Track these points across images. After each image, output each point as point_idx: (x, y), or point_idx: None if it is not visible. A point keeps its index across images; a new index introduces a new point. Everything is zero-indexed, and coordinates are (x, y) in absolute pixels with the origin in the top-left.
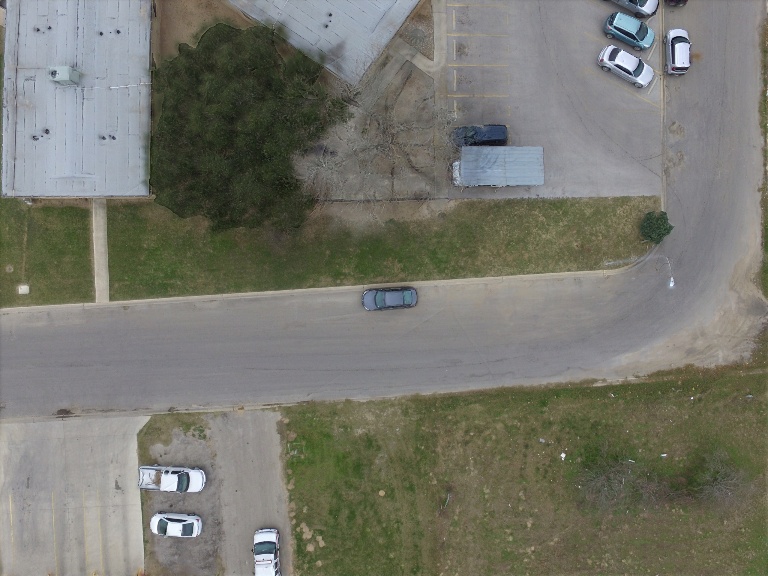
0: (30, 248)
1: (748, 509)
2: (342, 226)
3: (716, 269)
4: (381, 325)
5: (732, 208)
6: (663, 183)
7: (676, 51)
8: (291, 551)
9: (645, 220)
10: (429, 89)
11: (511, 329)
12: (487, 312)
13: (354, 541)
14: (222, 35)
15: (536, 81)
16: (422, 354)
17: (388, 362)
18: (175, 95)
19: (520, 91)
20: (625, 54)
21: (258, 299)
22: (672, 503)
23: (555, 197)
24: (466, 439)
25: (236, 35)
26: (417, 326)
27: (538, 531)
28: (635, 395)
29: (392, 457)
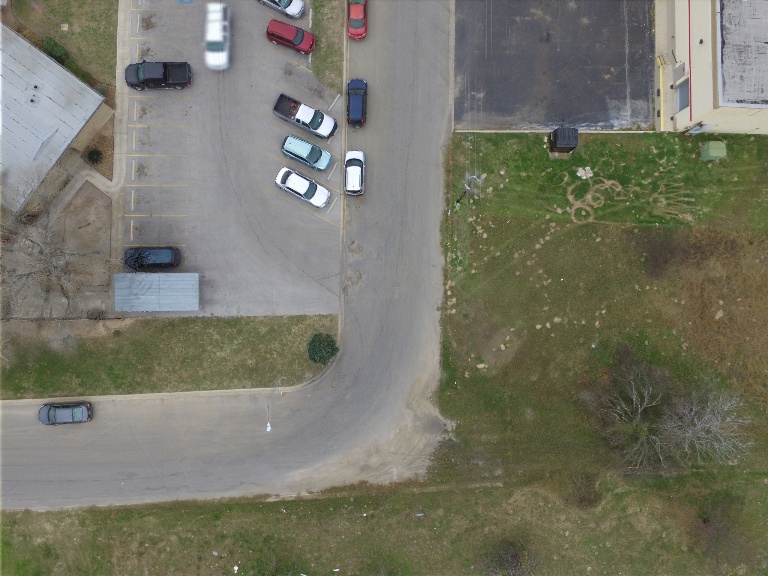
0: None
1: None
2: (21, 342)
3: (392, 387)
4: (60, 438)
5: (410, 327)
6: (341, 302)
7: (347, 174)
8: None
9: (310, 342)
10: (107, 209)
11: (186, 444)
12: (163, 427)
13: None
14: None
15: (214, 201)
16: (99, 467)
17: (66, 474)
18: None
19: (198, 211)
20: (295, 177)
21: None
22: None
23: (229, 316)
24: (141, 550)
25: None
26: (95, 439)
27: None
28: (307, 511)
29: (70, 566)
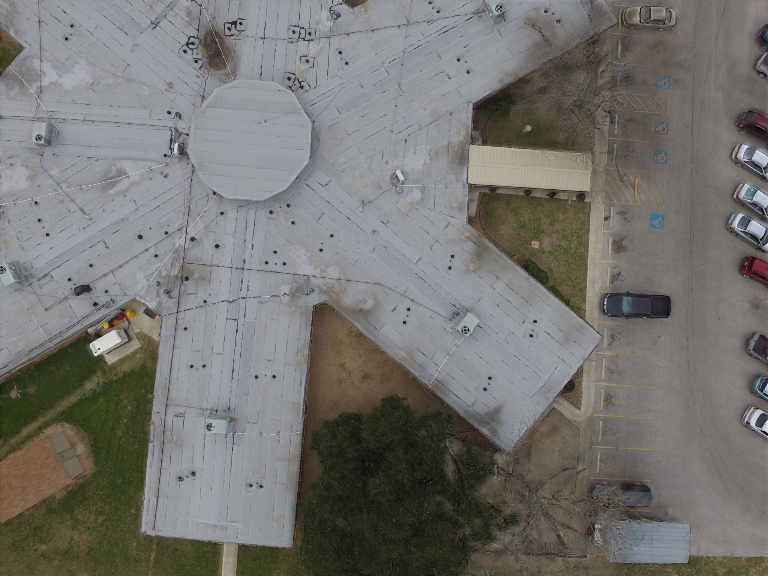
0: (157, 566)
1: None
2: None
3: None
4: None
5: None
6: None
7: None
8: None
9: None
10: (574, 439)
11: None
12: None
13: None
14: (394, 428)
15: (680, 435)
16: None
17: None
18: (341, 484)
19: (663, 445)
20: None
21: None
22: None
23: (690, 555)
24: None
25: (405, 423)
26: None
27: None
28: None
29: None
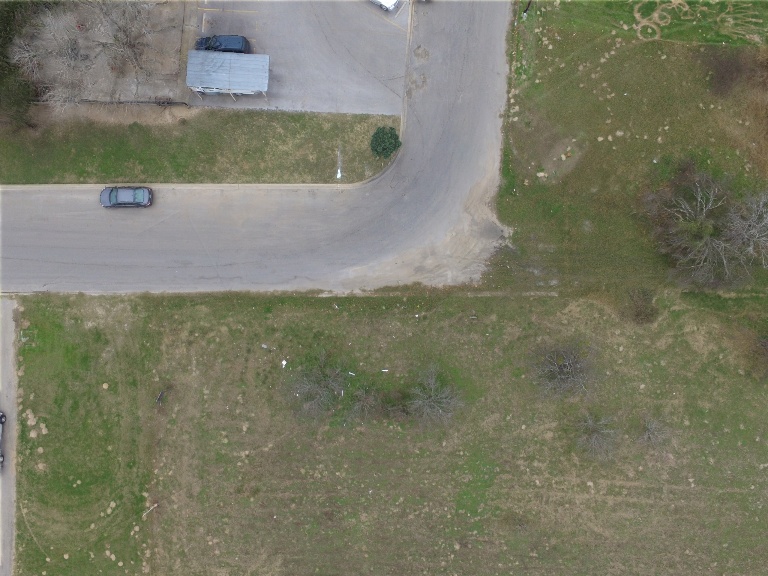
0: None
1: (468, 432)
2: (88, 126)
3: (451, 191)
4: (118, 223)
5: (471, 132)
6: (404, 104)
7: None
8: (16, 436)
9: None
10: (181, 1)
11: (242, 235)
12: (220, 217)
13: (76, 431)
14: None
15: None
16: (154, 253)
17: (121, 259)
18: None
19: (269, 8)
20: None
21: (7, 191)
22: (391, 420)
23: (294, 110)
24: (190, 339)
25: None
26: (152, 226)
27: (254, 436)
28: (359, 308)
29: (119, 352)
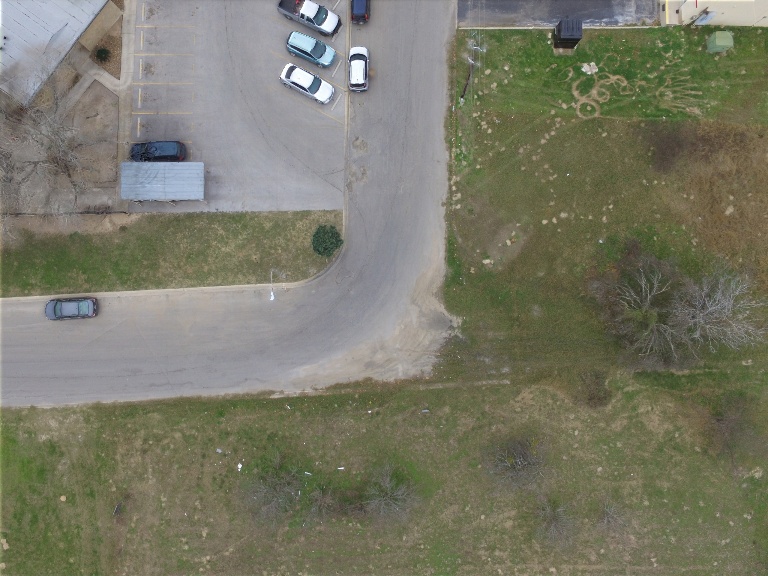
0: None
1: (427, 525)
2: (29, 238)
3: (397, 283)
4: (66, 334)
5: (414, 222)
6: (345, 197)
7: (351, 68)
8: None
9: (314, 234)
10: (114, 107)
11: (190, 340)
12: (167, 323)
13: (36, 545)
14: None
15: (220, 98)
16: (104, 363)
17: (71, 370)
18: None
19: (203, 108)
20: (300, 72)
21: None
22: (349, 517)
23: (234, 211)
24: (145, 447)
25: None
26: (100, 336)
27: (214, 541)
28: (311, 407)
29: (74, 463)
